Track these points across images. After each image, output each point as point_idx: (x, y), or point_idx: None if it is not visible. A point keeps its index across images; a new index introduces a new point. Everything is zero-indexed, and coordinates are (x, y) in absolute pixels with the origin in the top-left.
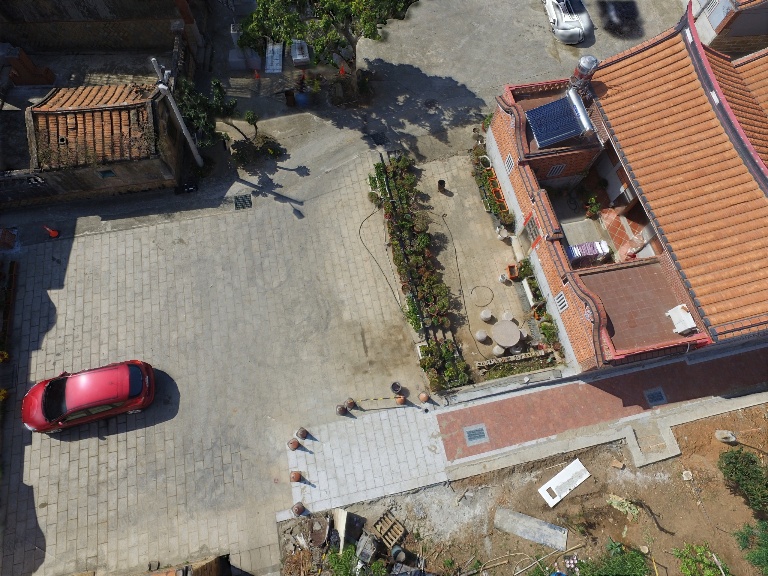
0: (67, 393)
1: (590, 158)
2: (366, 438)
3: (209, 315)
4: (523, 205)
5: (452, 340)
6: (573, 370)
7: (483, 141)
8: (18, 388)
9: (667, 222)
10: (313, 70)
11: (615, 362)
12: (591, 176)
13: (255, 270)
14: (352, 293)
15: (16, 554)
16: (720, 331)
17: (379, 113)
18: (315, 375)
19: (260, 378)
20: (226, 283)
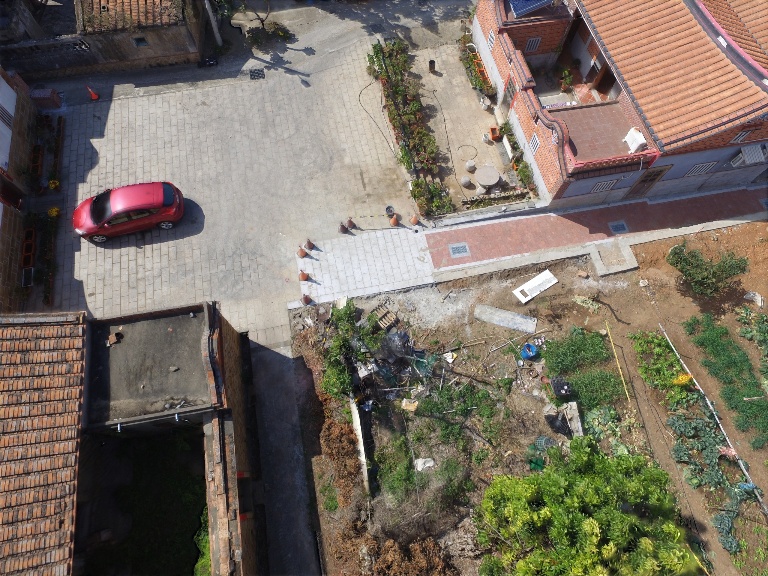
0: (112, 200)
1: (562, 32)
2: (364, 250)
3: (229, 158)
4: (503, 72)
5: (440, 184)
6: (545, 202)
7: (470, 32)
8: (68, 210)
9: (624, 65)
10: None
11: (577, 176)
12: (566, 58)
13: (268, 125)
14: (352, 143)
15: None
16: (666, 142)
17: (377, 9)
18: (320, 203)
19: (273, 205)
20: (243, 135)
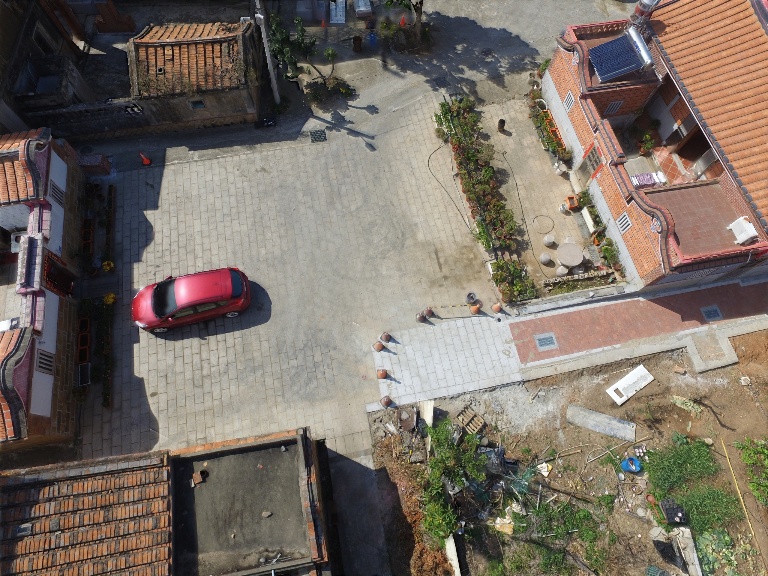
0: (176, 292)
1: (647, 95)
2: (445, 342)
3: (293, 234)
4: (583, 138)
5: (518, 262)
6: (635, 286)
7: (539, 86)
8: (124, 294)
9: (727, 144)
10: (374, 21)
11: (681, 269)
12: (643, 118)
13: (333, 196)
14: (424, 217)
15: (133, 434)
16: None
17: (439, 60)
18: (394, 287)
19: (344, 289)
20: (307, 207)
